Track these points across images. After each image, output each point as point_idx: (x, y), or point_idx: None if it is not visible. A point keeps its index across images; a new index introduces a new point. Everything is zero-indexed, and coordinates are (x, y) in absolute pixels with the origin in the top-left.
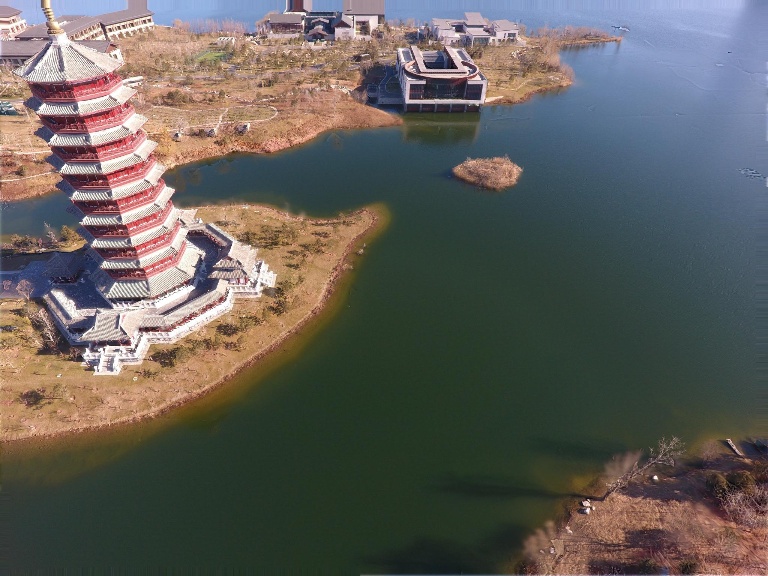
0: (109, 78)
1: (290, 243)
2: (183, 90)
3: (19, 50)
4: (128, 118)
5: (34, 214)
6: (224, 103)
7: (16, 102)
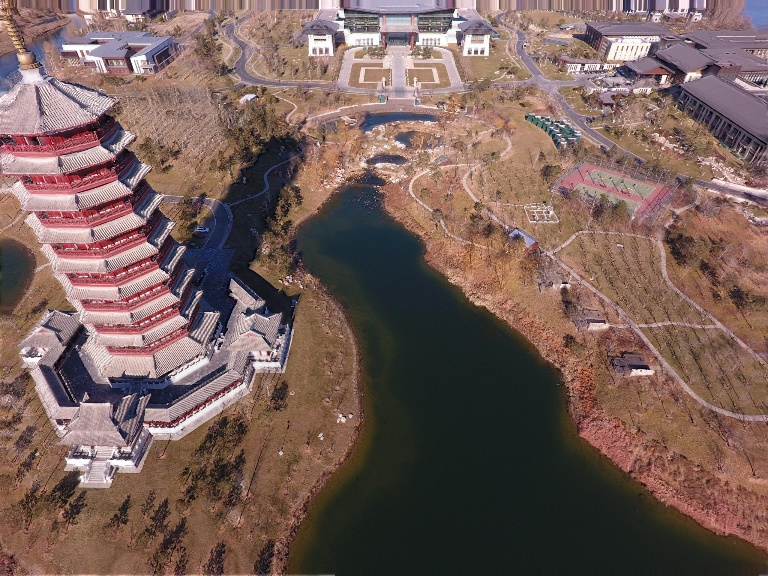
0: (41, 141)
1: (193, 502)
2: (763, 252)
3: (709, 94)
4: (53, 193)
5: (360, 228)
6: (740, 316)
7: (596, 140)
